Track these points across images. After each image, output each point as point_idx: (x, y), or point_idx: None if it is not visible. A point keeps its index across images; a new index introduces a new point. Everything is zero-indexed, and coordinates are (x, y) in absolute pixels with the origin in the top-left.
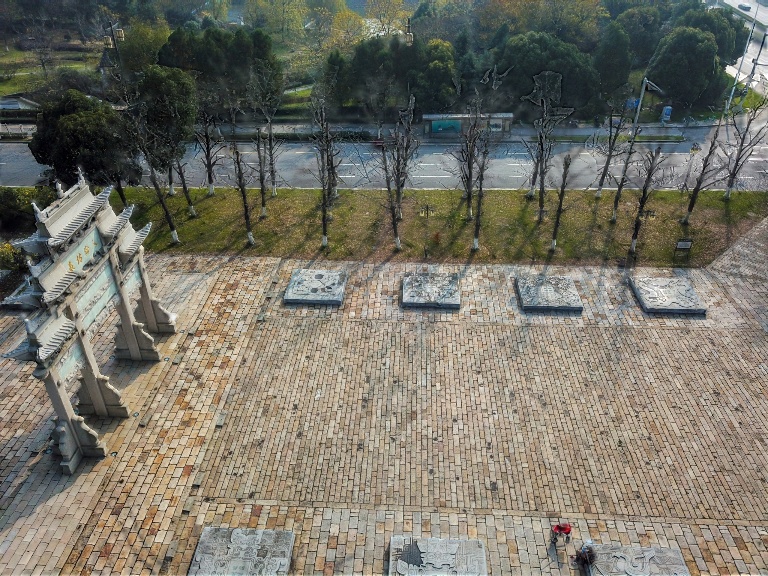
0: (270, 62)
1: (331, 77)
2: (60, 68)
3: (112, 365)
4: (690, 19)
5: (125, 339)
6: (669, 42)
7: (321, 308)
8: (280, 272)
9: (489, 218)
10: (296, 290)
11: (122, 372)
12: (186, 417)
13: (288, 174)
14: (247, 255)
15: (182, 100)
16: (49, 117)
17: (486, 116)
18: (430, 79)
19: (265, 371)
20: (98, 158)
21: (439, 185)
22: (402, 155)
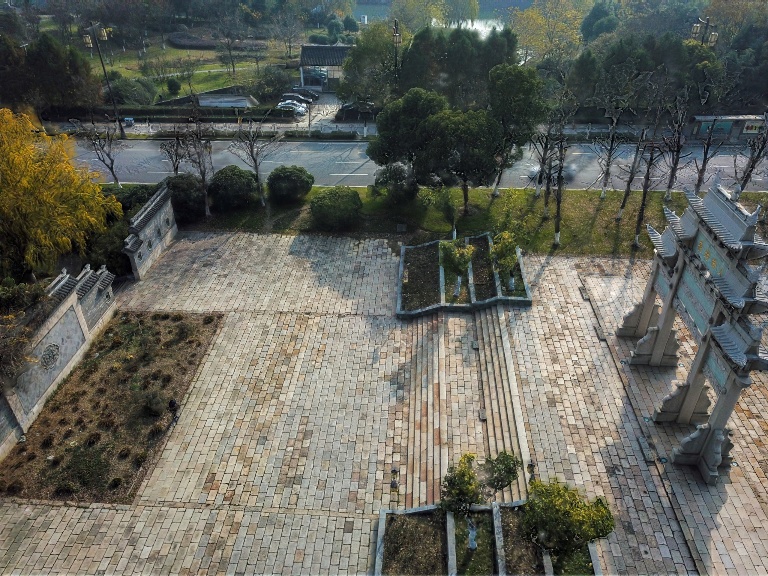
0: (515, 61)
1: (734, 77)
2: (267, 66)
3: (633, 371)
4: None
5: (653, 344)
6: None
7: None
8: None
9: None
10: None
11: (651, 378)
12: (764, 426)
13: (589, 175)
14: (644, 258)
15: (541, 100)
16: (401, 116)
17: (762, 118)
18: (695, 80)
19: None
20: (484, 158)
21: (759, 188)
22: None
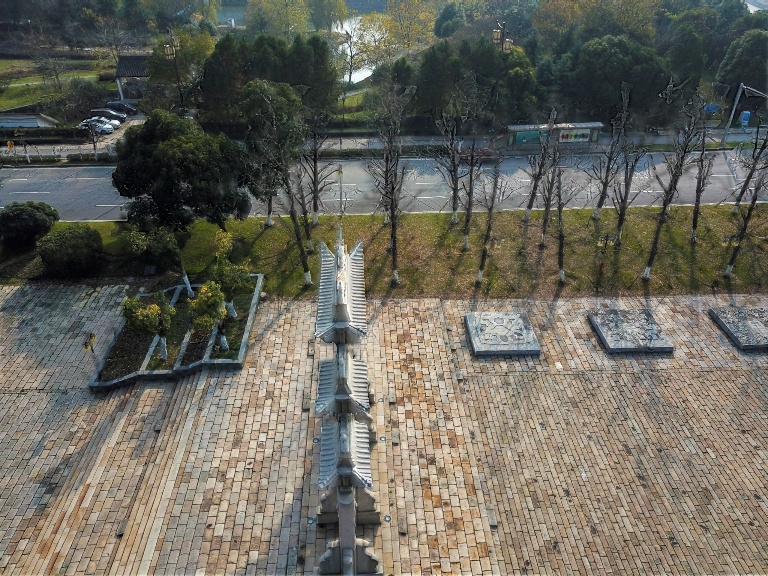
0: (328, 71)
1: (485, 92)
2: (73, 79)
3: None
4: (751, 21)
5: None
6: (744, 45)
7: (520, 359)
8: (448, 316)
9: (637, 241)
10: (484, 339)
11: None
12: (448, 517)
13: None
14: (399, 297)
15: None
16: (137, 142)
17: (575, 126)
18: (509, 87)
19: (504, 446)
20: (216, 191)
21: None
22: (535, 175)
